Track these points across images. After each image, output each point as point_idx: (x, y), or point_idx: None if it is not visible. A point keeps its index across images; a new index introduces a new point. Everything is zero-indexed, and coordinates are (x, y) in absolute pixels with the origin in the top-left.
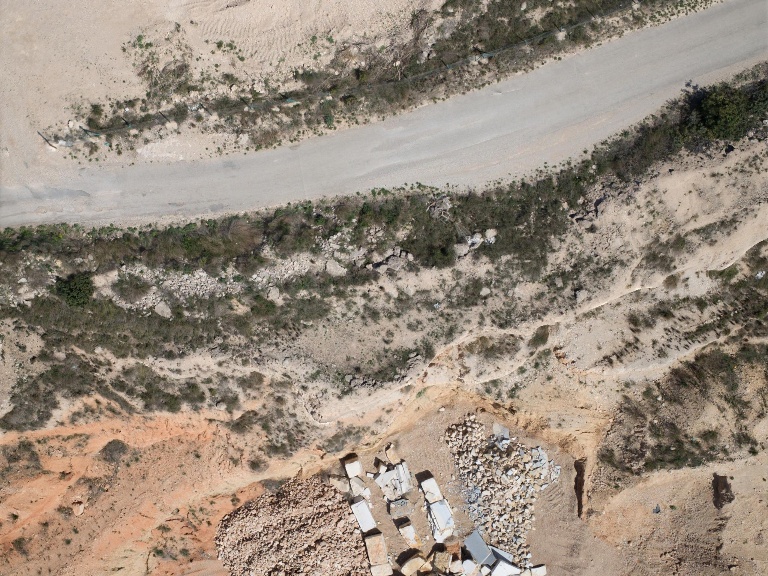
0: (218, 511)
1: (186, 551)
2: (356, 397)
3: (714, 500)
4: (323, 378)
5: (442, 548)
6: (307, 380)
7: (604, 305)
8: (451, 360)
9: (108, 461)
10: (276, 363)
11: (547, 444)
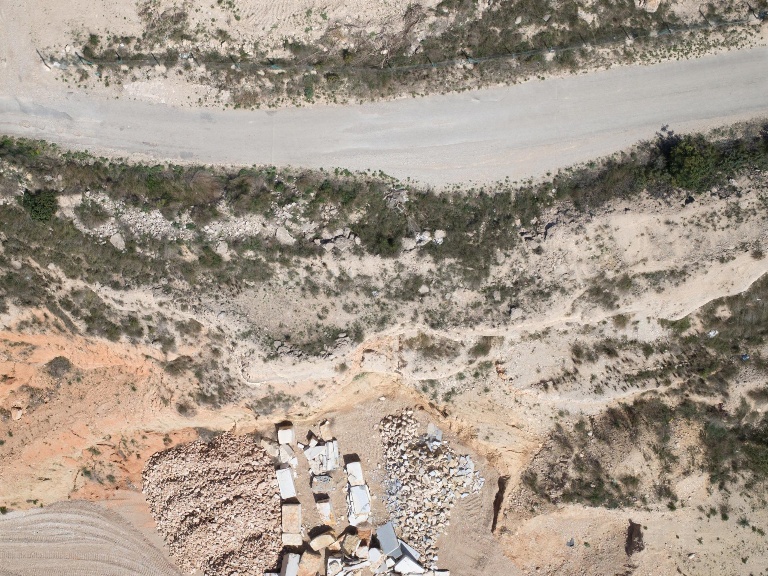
0: (149, 447)
1: (112, 477)
2: (280, 364)
3: (626, 546)
4: (253, 339)
5: (354, 531)
6: (238, 337)
7: (551, 330)
8: (391, 351)
9: (52, 375)
10: (212, 315)
11: (476, 455)
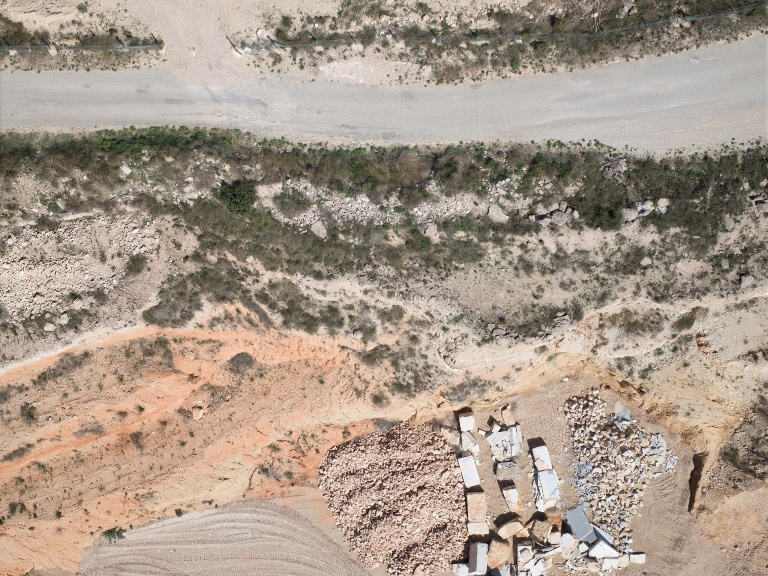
0: (328, 441)
1: (290, 474)
2: (496, 347)
3: None
4: (466, 322)
5: (543, 517)
6: (450, 322)
7: (759, 298)
8: (590, 329)
9: (234, 372)
10: (422, 300)
11: (668, 432)
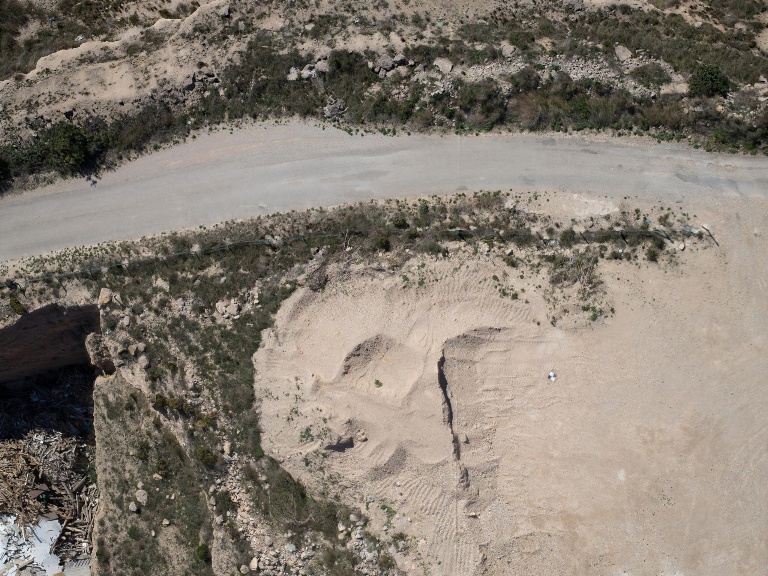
0: None
1: None
2: None
3: None
4: None
5: None
6: None
7: None
8: None
9: None
10: None
11: None
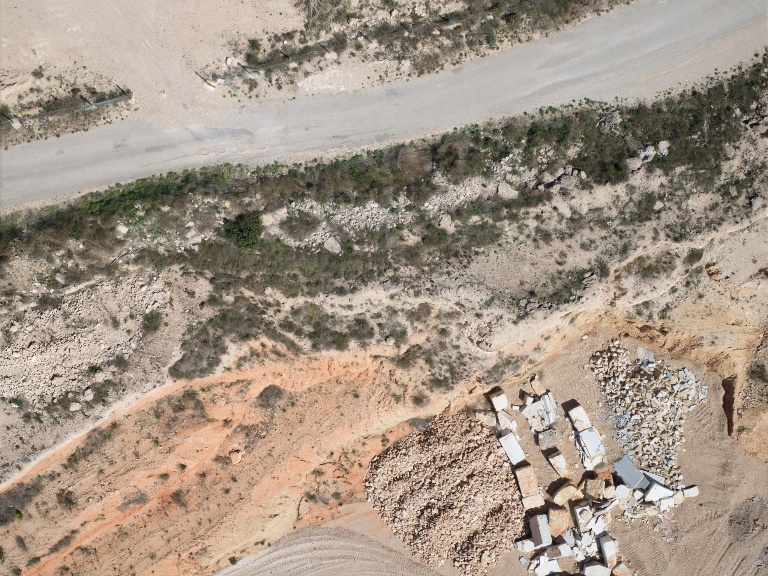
0: (369, 452)
1: (338, 494)
2: (532, 321)
3: None
4: (498, 304)
5: (592, 475)
6: (482, 307)
7: None
8: (606, 283)
9: (264, 407)
10: (450, 292)
11: (693, 365)
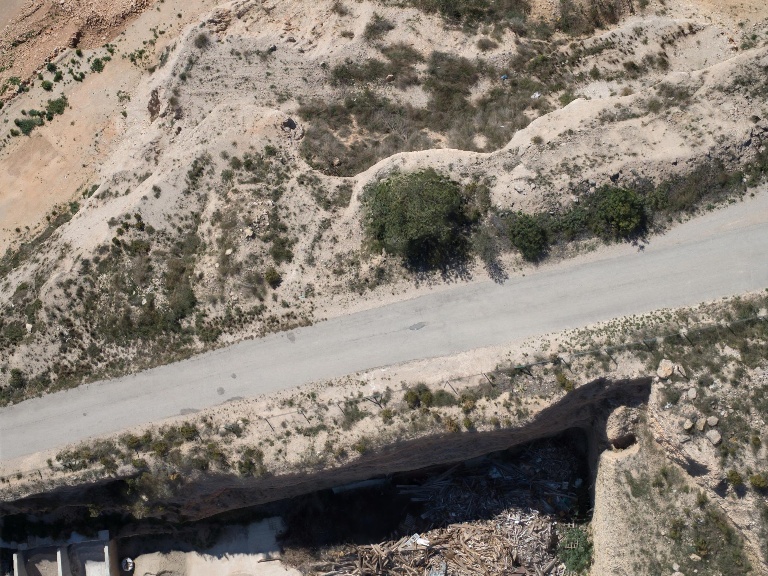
0: None
1: None
2: None
3: None
4: None
5: None
6: None
7: None
8: None
9: None
10: None
11: None
